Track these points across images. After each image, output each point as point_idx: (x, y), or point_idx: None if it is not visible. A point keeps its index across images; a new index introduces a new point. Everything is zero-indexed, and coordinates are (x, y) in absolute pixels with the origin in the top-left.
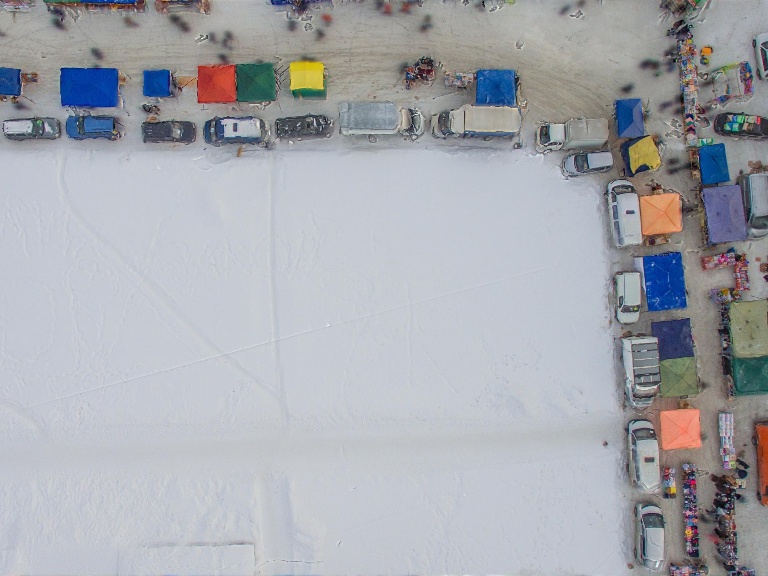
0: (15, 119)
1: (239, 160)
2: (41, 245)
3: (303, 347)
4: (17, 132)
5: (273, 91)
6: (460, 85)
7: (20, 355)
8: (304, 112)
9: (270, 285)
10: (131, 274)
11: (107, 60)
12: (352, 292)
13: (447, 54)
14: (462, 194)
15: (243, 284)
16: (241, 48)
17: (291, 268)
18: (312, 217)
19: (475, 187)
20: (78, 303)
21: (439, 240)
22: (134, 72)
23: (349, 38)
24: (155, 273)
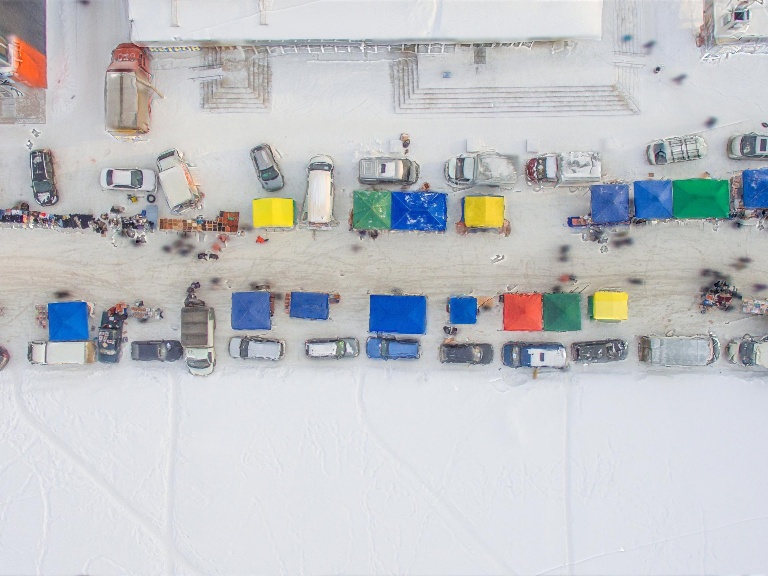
0: (318, 339)
1: (536, 383)
2: (339, 464)
3: (597, 571)
4: (322, 355)
5: (579, 321)
6: (758, 313)
7: (319, 575)
8: (599, 334)
9: (565, 508)
10: (427, 494)
11: (405, 279)
12: (647, 517)
13: (742, 279)
14: (754, 418)
15: (538, 507)
16: (537, 269)
17: (587, 492)
18: (608, 441)
19: (765, 410)
20: (375, 523)
21: (734, 466)
22: (431, 291)
23: (644, 261)
24: (452, 495)
